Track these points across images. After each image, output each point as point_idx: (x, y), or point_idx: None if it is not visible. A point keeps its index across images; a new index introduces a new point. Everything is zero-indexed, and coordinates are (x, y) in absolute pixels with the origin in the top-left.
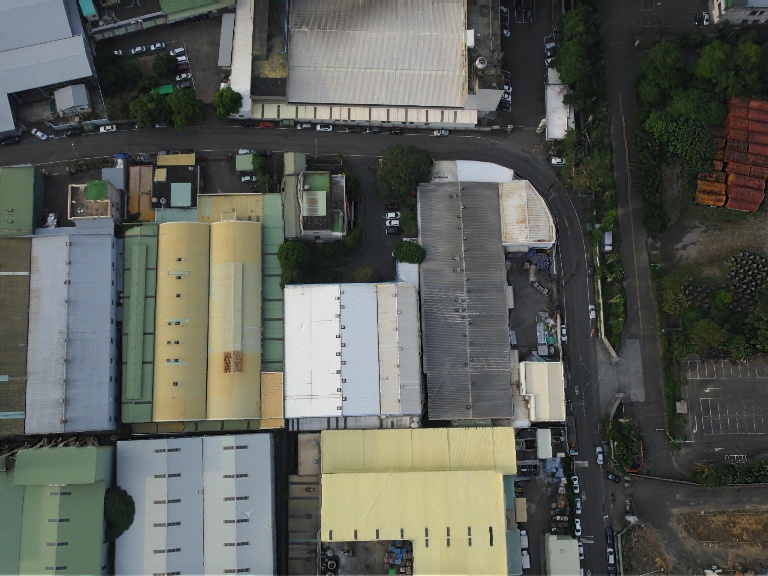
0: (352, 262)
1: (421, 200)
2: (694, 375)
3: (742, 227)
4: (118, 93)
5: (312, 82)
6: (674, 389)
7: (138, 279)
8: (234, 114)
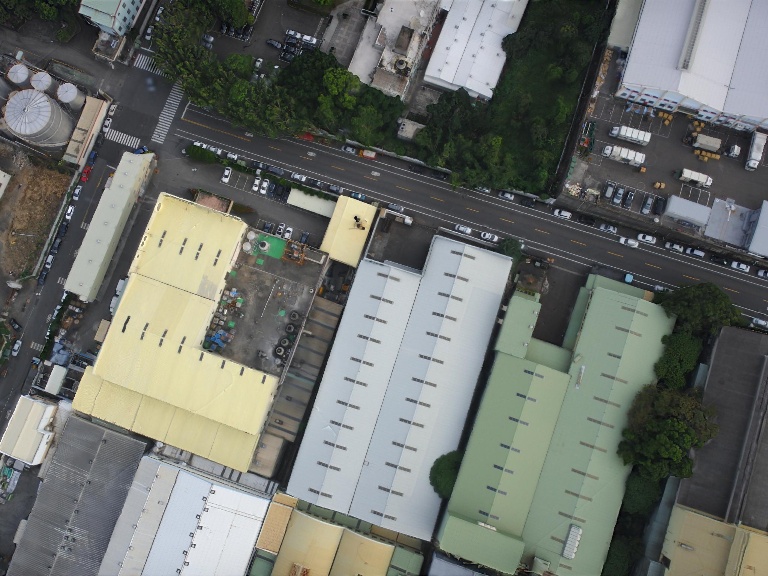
0: None
1: None
2: None
3: None
4: None
5: None
6: None
7: None
8: None
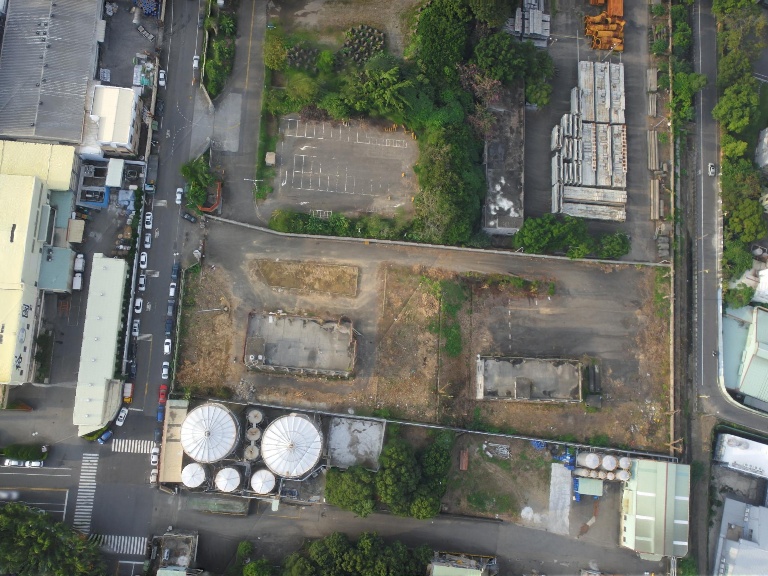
0: None
1: None
2: (292, 133)
3: (368, 3)
4: None
5: None
6: (269, 143)
7: None
8: None
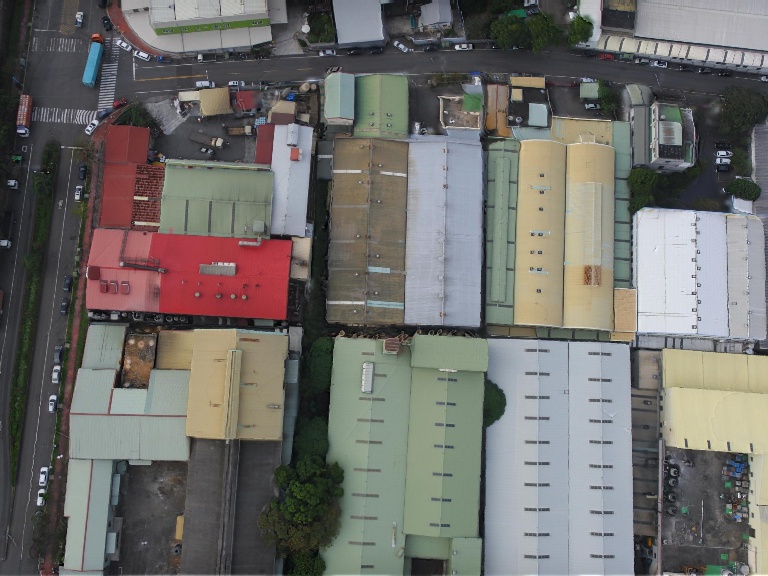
0: (687, 194)
1: (756, 141)
2: None
3: None
4: (477, 13)
5: (657, 18)
6: None
7: (503, 190)
8: (582, 43)
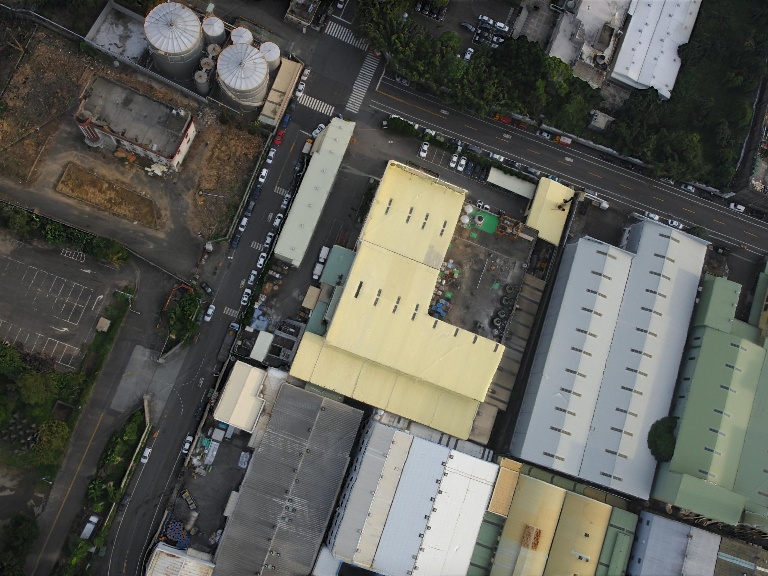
0: None
1: None
2: (71, 350)
3: None
4: None
5: None
6: (100, 345)
7: None
8: None
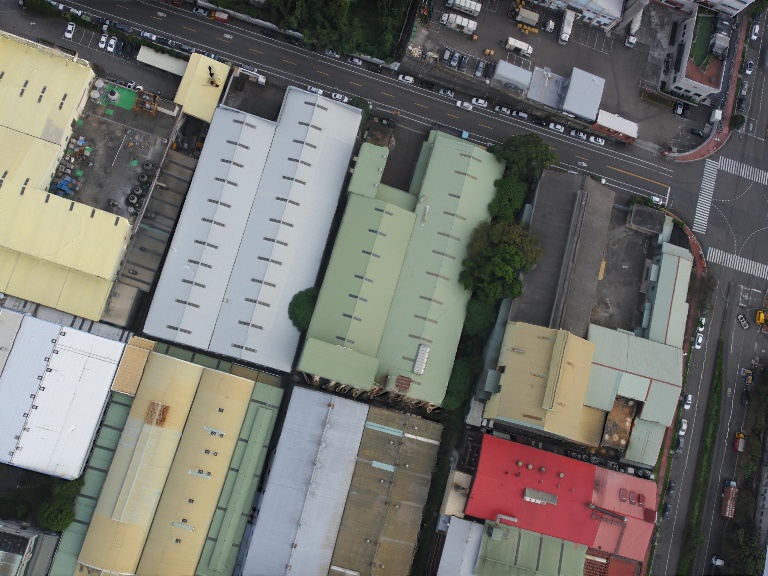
0: None
1: None
2: None
3: None
4: None
5: None
6: None
7: (227, 531)
8: None
